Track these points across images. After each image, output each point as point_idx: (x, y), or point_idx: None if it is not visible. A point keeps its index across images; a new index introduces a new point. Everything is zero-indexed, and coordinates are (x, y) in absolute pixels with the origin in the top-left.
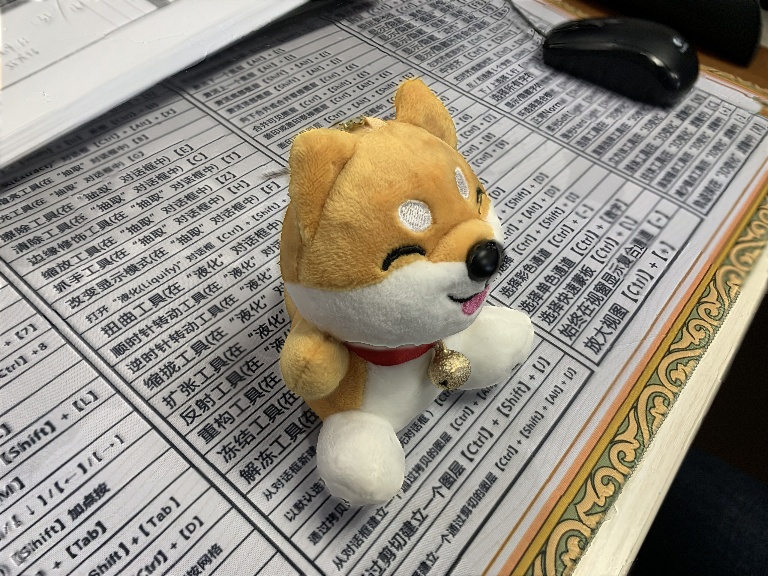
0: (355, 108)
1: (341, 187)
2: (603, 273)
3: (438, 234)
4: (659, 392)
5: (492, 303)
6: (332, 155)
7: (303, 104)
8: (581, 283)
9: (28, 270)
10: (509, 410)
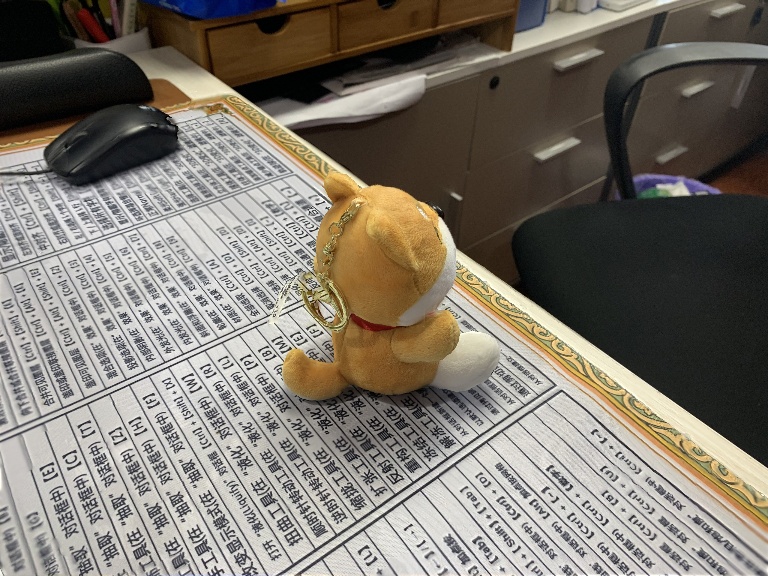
0: (62, 320)
1: None
2: None
3: None
4: None
5: None
6: None
7: (29, 359)
8: None
9: None
10: None
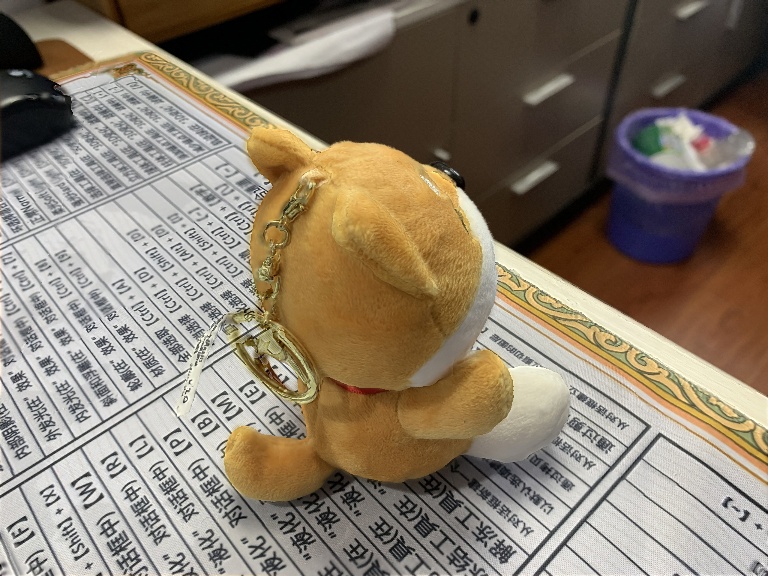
0: None
1: None
2: None
3: None
4: None
5: None
6: None
7: None
8: None
9: None
10: None
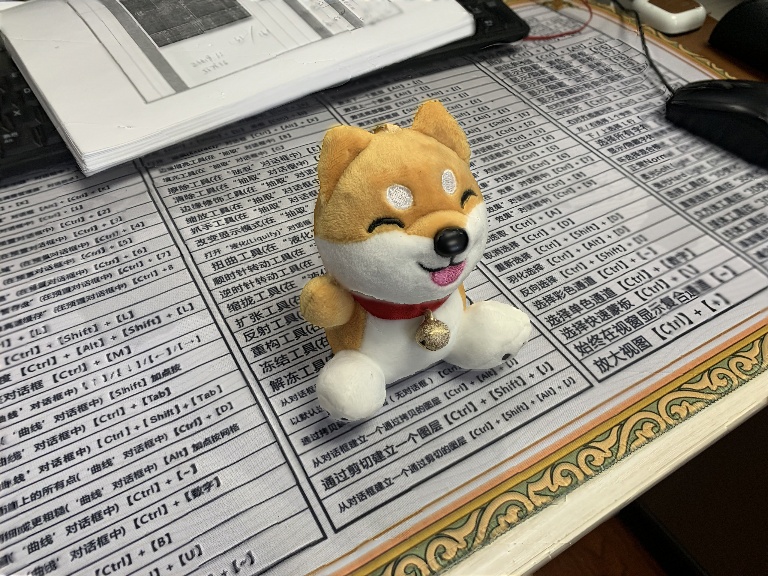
0: None
1: (352, 168)
2: (641, 308)
3: (416, 214)
4: (652, 419)
5: (521, 310)
6: (348, 144)
7: None
8: (614, 312)
9: (178, 215)
10: (499, 395)
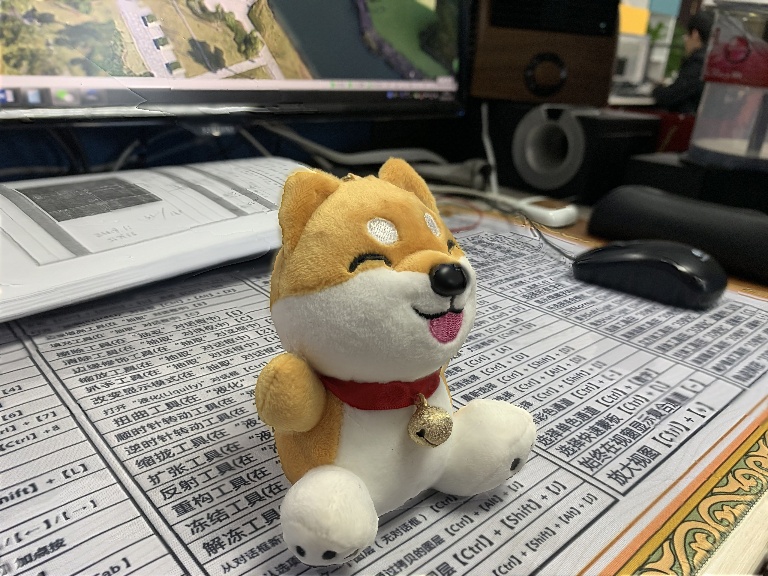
0: None
1: (322, 210)
2: (631, 421)
3: (403, 250)
4: (701, 528)
5: None
6: (316, 184)
7: None
8: (606, 427)
9: (69, 376)
10: (515, 523)
